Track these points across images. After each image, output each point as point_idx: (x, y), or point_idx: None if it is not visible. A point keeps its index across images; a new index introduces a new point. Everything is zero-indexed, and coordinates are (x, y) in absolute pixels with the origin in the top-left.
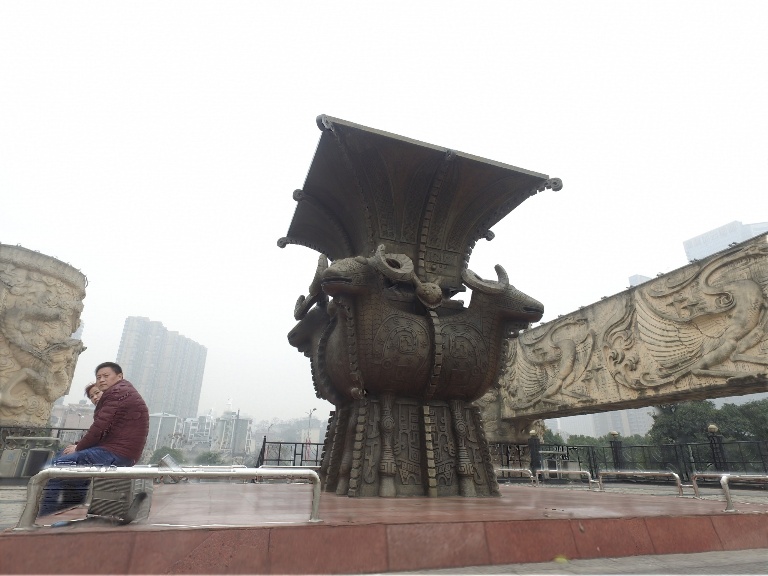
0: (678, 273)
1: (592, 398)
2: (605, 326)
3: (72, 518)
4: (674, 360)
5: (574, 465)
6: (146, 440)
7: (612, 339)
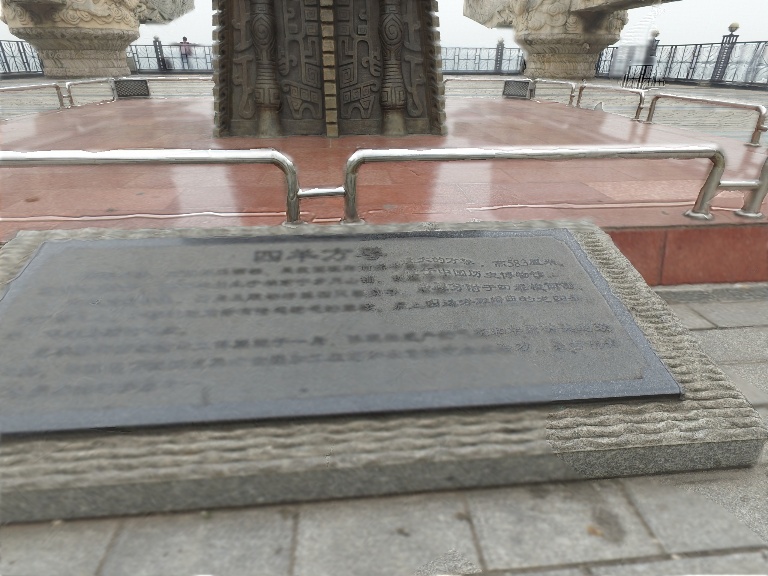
0: None
1: None
2: None
3: None
4: None
5: None
6: (616, 63)
7: None
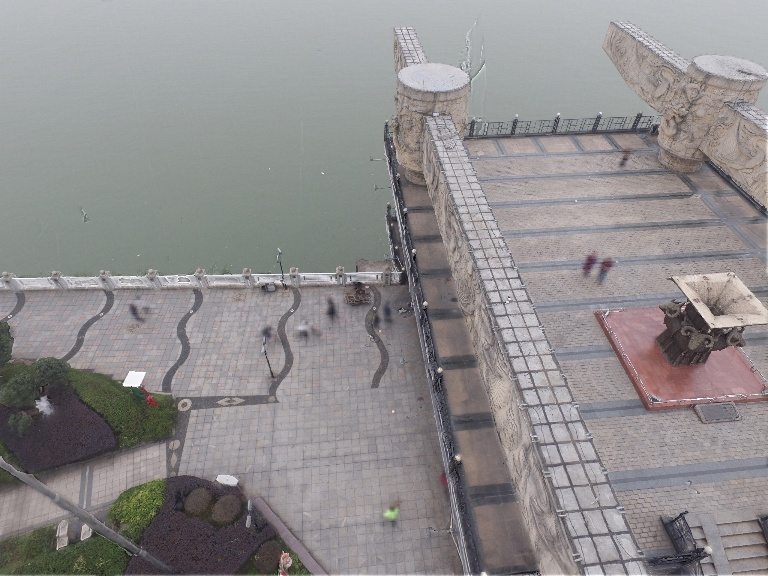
0: None
1: None
2: None
3: None
4: None
5: None
6: None
7: None
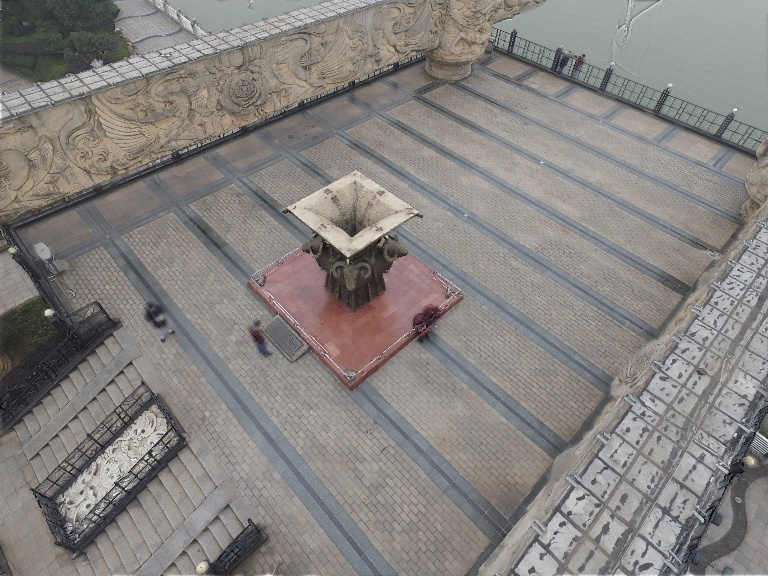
0: (130, 83)
1: (65, 193)
2: (64, 131)
3: (447, 302)
4: (140, 147)
5: (51, 247)
6: None
7: (77, 141)
